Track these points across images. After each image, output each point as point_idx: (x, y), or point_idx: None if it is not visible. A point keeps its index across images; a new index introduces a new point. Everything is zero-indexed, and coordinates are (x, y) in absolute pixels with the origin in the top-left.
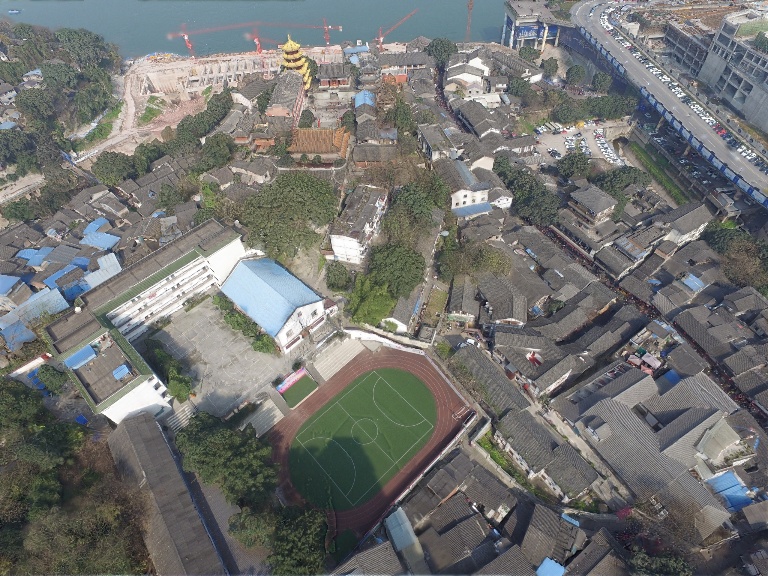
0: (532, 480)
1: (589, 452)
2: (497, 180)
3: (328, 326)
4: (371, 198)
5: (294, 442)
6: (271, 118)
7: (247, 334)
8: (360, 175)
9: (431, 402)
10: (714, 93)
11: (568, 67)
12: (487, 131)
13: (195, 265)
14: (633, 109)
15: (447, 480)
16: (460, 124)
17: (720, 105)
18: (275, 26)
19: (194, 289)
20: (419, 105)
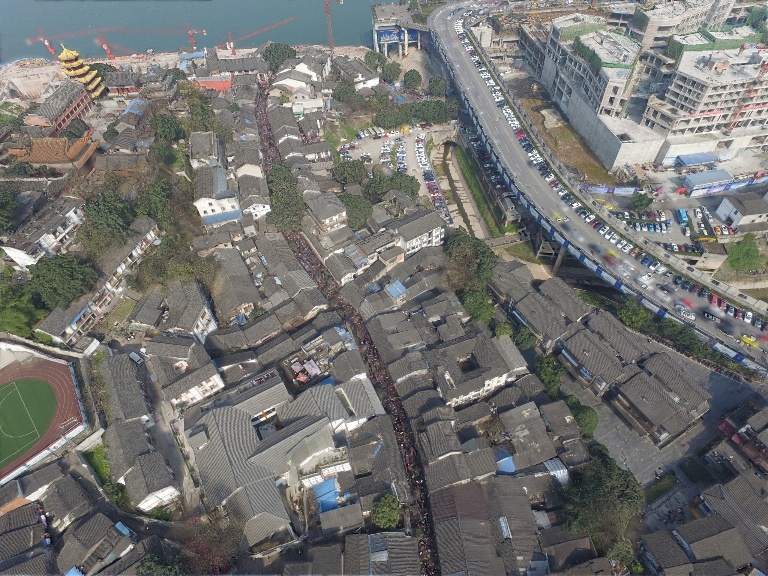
0: None
1: None
2: (262, 187)
3: None
4: (65, 209)
5: None
6: (26, 128)
7: None
8: (99, 184)
9: (51, 412)
10: (550, 96)
11: (426, 70)
12: (283, 137)
13: None
14: (456, 113)
15: (10, 491)
16: None
17: (551, 108)
18: (162, 30)
19: None
20: (225, 111)
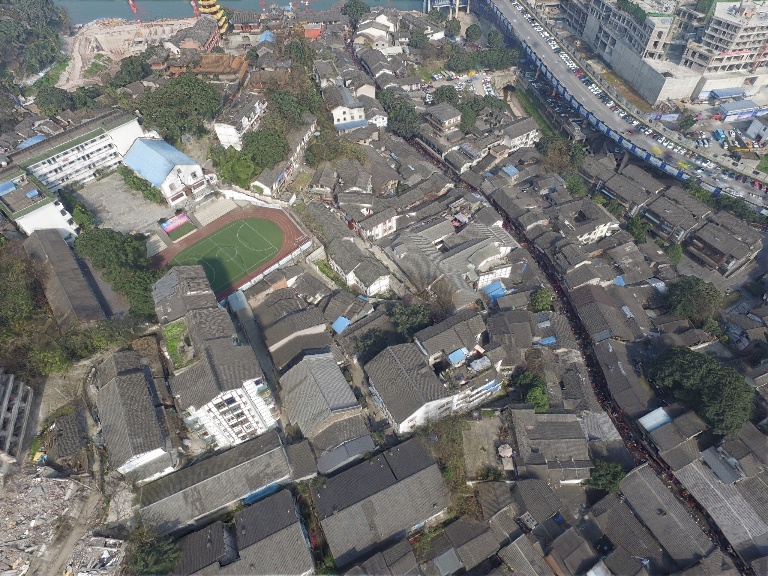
0: (350, 286)
1: (396, 269)
2: None
3: (208, 189)
4: (252, 101)
5: (172, 261)
6: (184, 50)
7: (139, 188)
8: None
9: (280, 236)
10: (592, 50)
11: None
12: (380, 72)
13: (102, 142)
14: (517, 60)
15: (278, 275)
16: (363, 69)
17: (595, 59)
18: None
19: (103, 163)
20: None
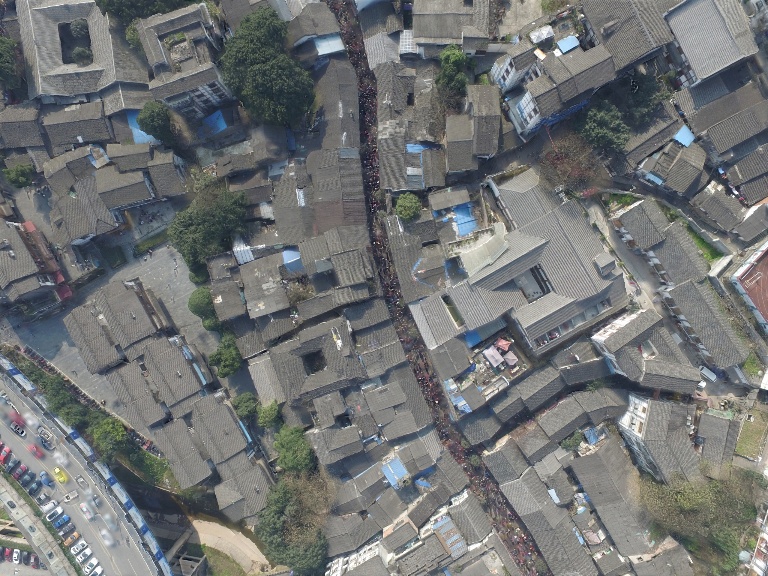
0: None
1: None
2: None
3: None
4: None
5: None
6: None
7: None
8: None
9: None
10: None
11: None
12: None
13: None
14: None
15: None
16: None
17: None
18: None
19: None
20: None
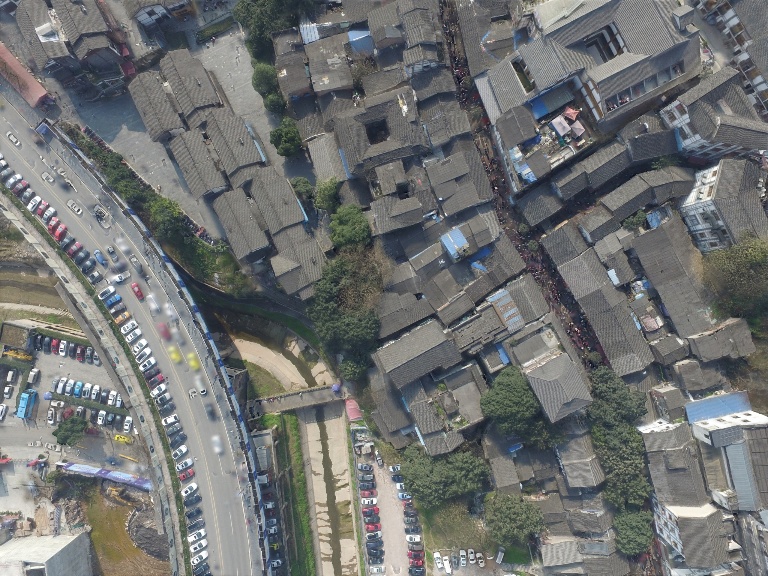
0: None
1: None
2: (663, 479)
3: None
4: None
5: None
6: None
7: None
8: None
9: None
10: None
11: None
12: None
13: None
14: None
15: None
16: None
17: None
18: None
19: None
20: None
